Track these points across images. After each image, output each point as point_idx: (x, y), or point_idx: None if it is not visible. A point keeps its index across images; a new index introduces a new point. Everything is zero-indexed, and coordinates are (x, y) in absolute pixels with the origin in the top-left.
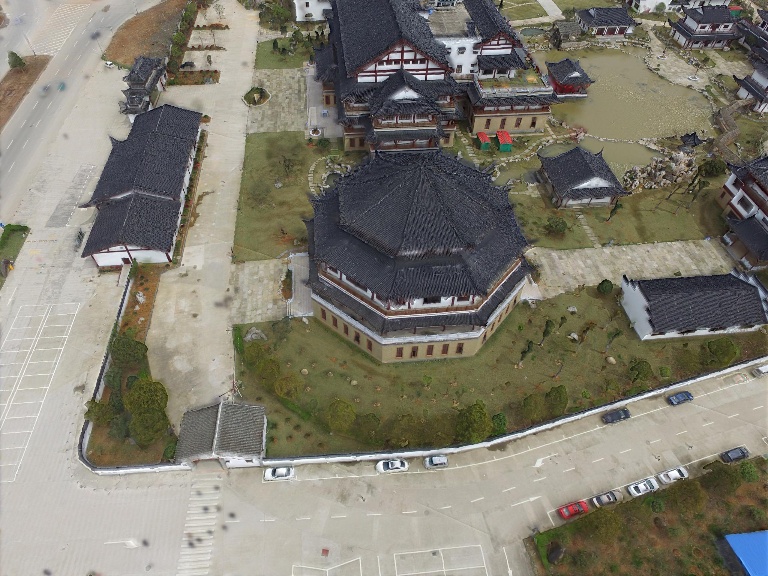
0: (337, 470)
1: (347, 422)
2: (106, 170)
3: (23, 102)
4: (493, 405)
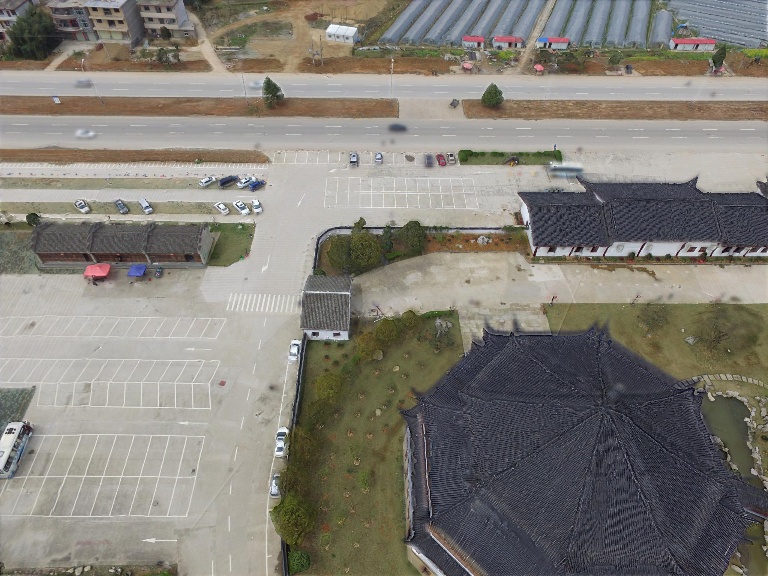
0: (291, 395)
1: (320, 391)
2: (640, 184)
3: (747, 121)
4: (332, 568)
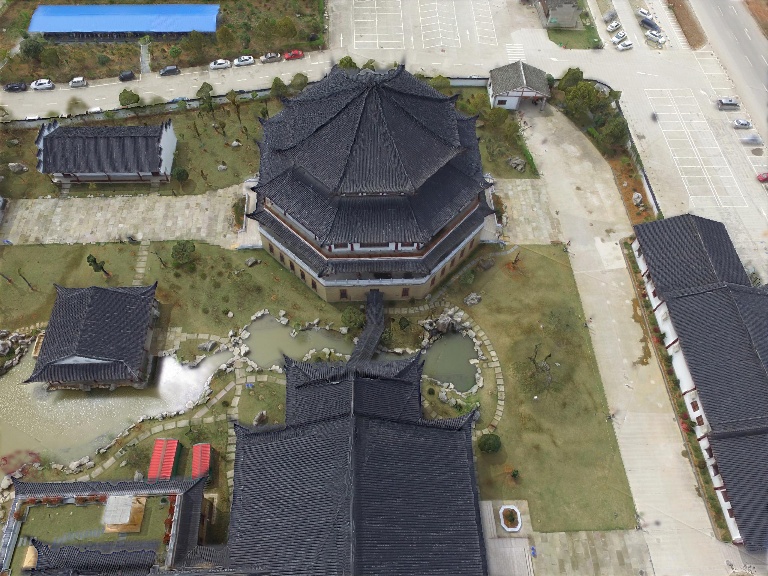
0: None
1: None
2: None
3: None
4: None
